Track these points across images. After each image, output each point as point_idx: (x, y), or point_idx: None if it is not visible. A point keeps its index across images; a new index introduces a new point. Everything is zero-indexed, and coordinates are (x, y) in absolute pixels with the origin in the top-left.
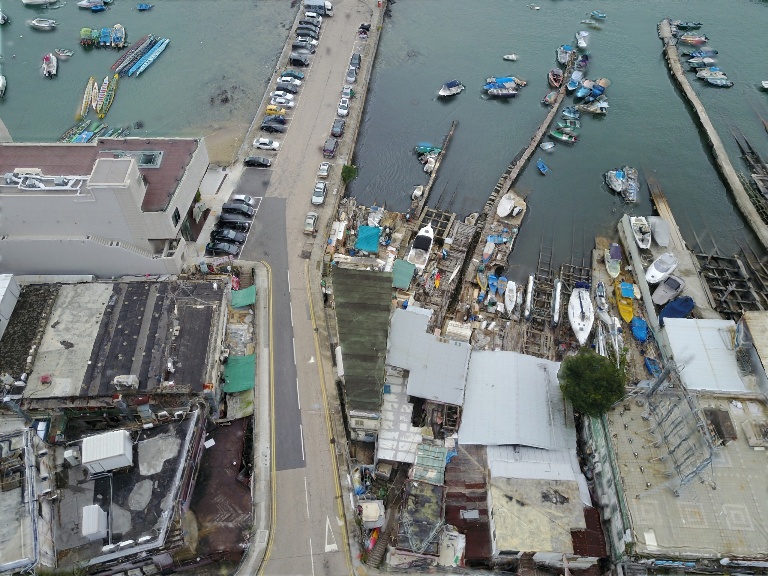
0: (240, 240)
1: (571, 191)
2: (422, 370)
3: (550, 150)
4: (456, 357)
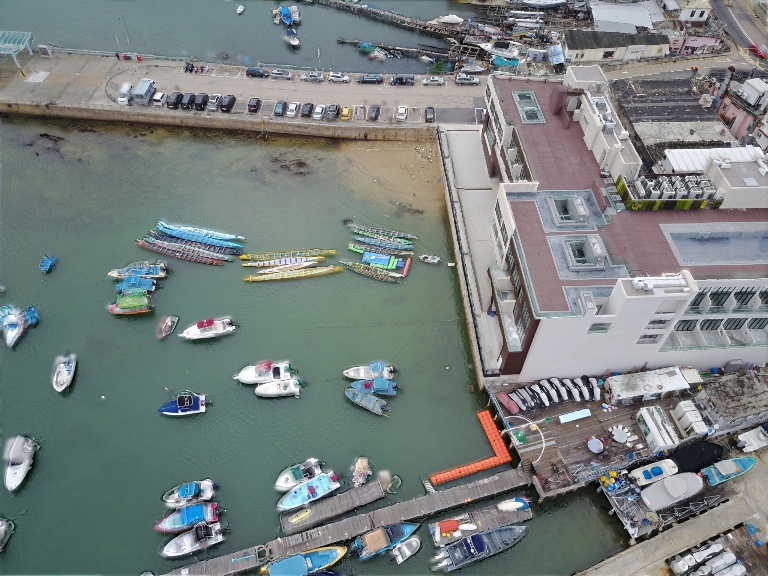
0: None
1: (415, 6)
2: None
3: (371, 7)
4: (606, 23)
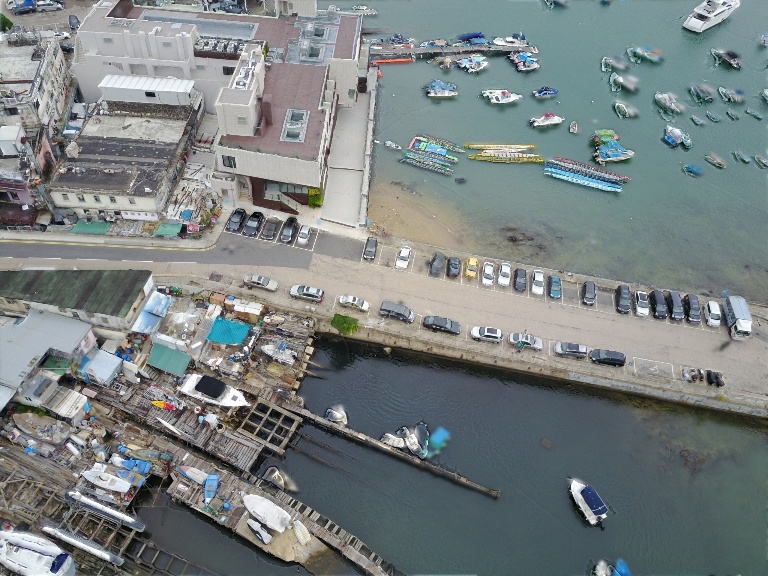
0: (245, 230)
1: None
2: (8, 338)
3: None
4: (7, 369)
